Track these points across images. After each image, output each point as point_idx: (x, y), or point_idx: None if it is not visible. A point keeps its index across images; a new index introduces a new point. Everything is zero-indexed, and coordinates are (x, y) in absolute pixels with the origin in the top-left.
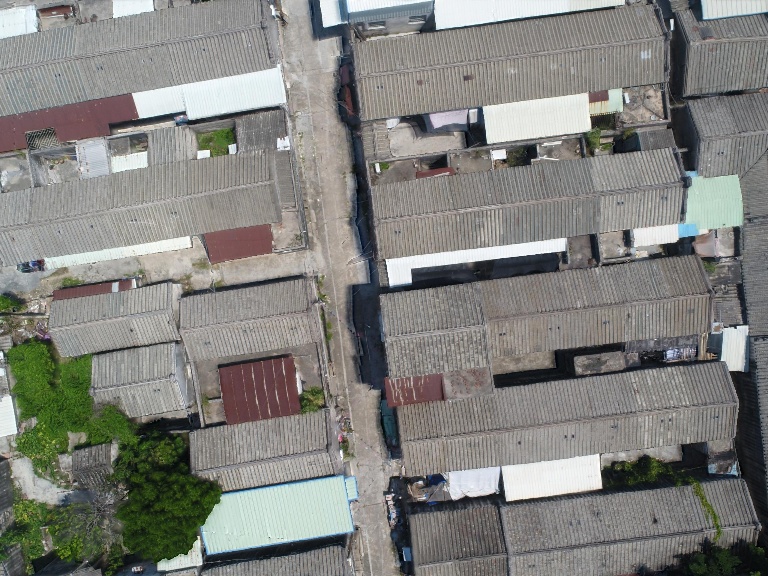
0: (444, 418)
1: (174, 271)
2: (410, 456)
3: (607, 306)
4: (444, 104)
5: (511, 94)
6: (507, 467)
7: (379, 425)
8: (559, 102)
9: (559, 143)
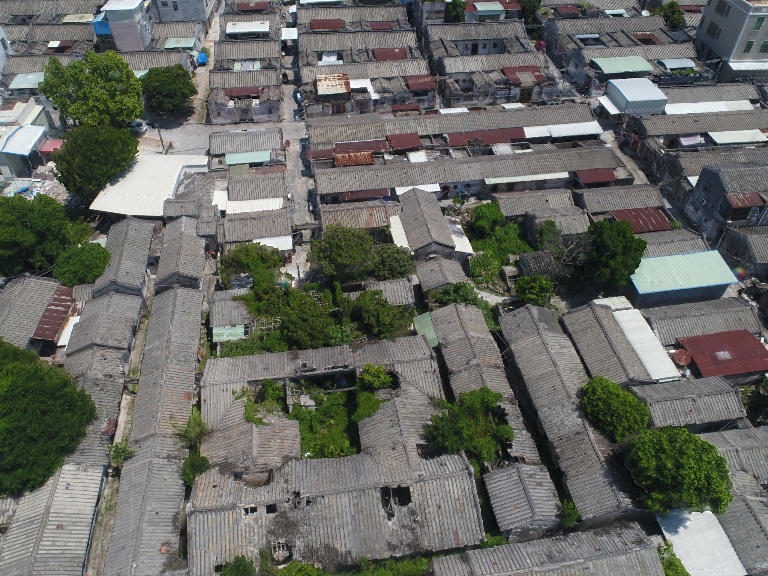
0: (765, 231)
1: None
2: (755, 246)
3: None
4: (688, 130)
5: (721, 128)
6: None
7: None
8: (746, 132)
9: (754, 147)
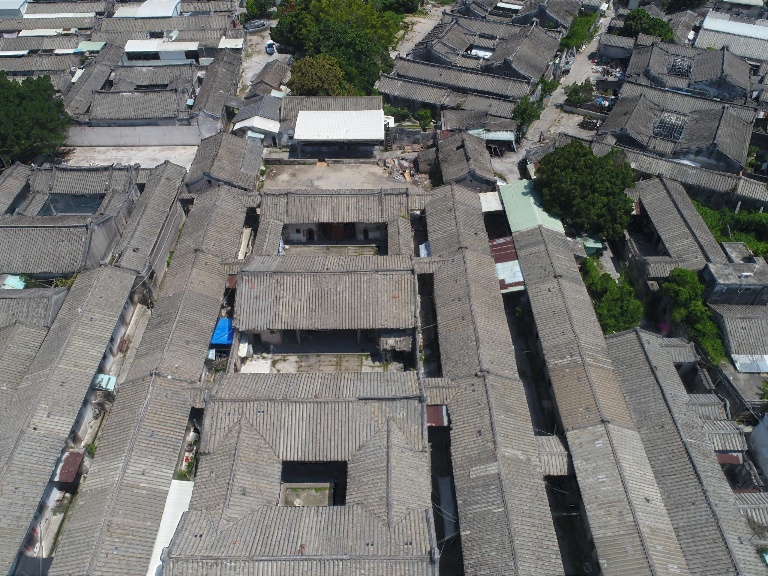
0: None
1: None
2: None
3: None
4: (7, 28)
5: None
6: None
7: None
8: None
9: None
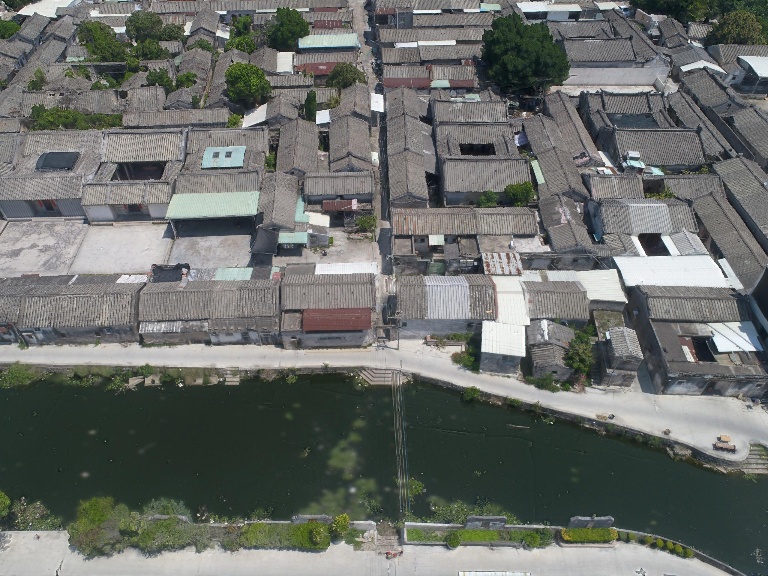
0: None
1: None
2: (382, 34)
3: (455, 14)
4: None
5: None
6: (420, 42)
7: (371, 52)
8: None
9: None
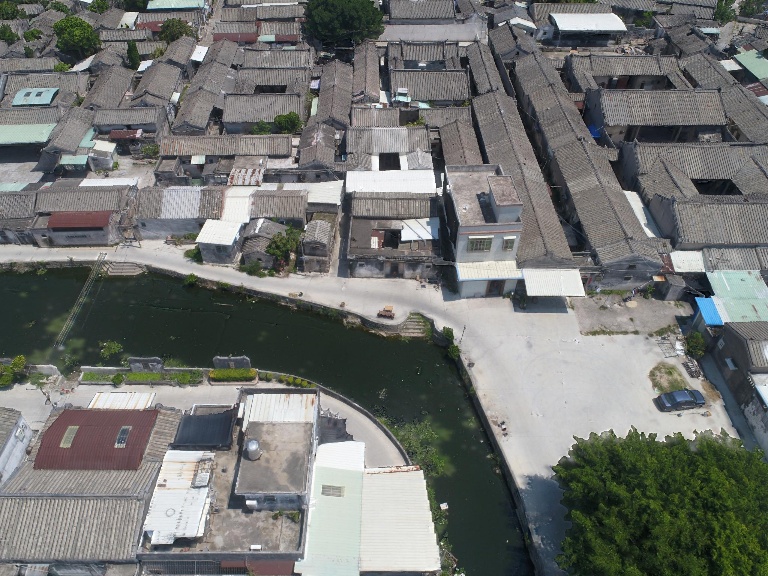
0: None
1: None
2: None
3: None
4: None
5: None
6: (265, 4)
7: None
8: None
9: None
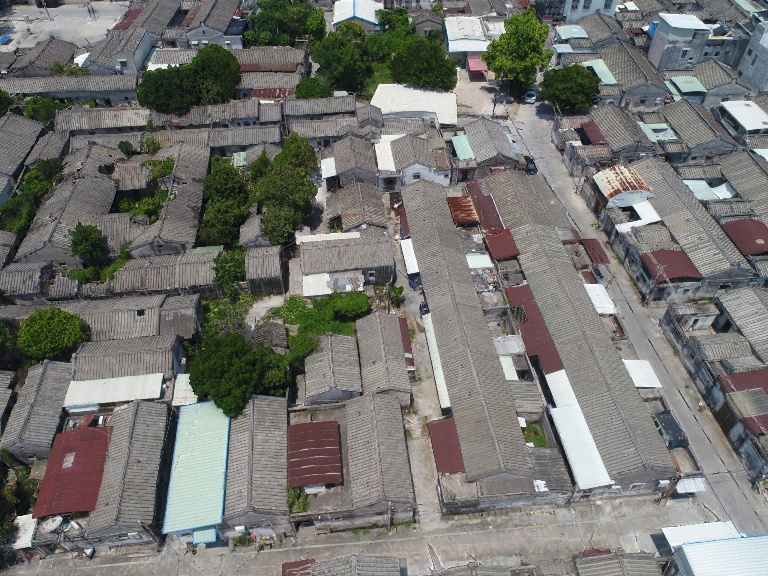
0: None
1: (421, 402)
2: None
3: None
4: None
5: None
6: None
7: None
8: None
9: None
